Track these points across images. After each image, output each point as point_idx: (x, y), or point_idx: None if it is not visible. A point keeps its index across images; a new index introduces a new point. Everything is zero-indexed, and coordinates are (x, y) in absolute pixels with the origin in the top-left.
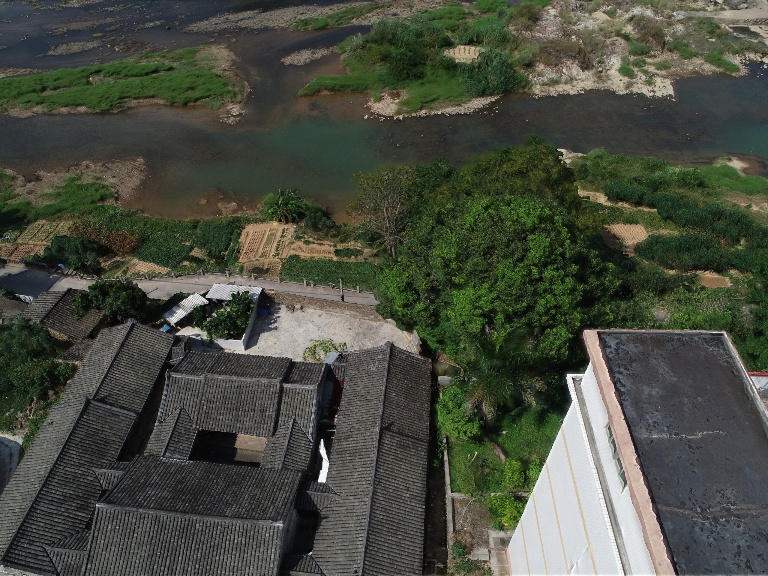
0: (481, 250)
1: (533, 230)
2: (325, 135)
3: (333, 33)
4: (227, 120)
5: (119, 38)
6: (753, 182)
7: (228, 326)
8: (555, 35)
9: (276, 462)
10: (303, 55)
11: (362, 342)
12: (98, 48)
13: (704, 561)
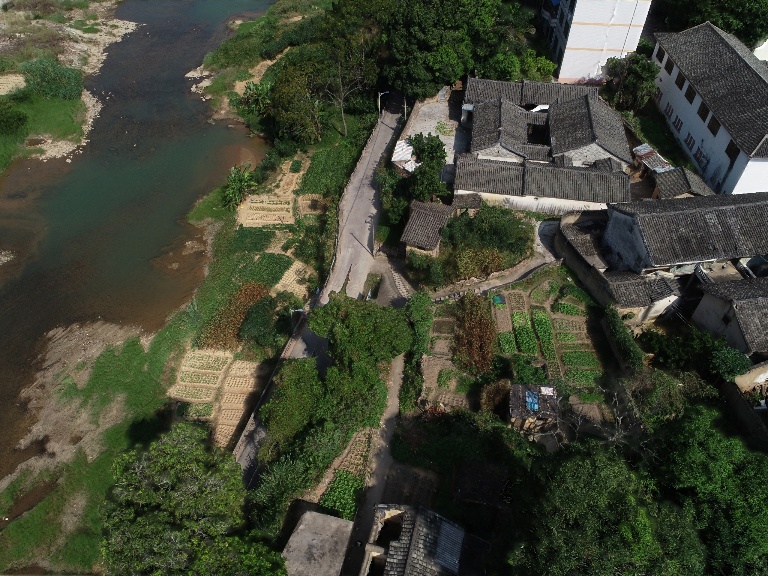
0: None
1: None
2: (82, 191)
3: None
4: (0, 261)
5: None
6: (265, 20)
7: None
8: (5, 41)
9: (543, 117)
10: None
11: (436, 117)
12: None
13: None
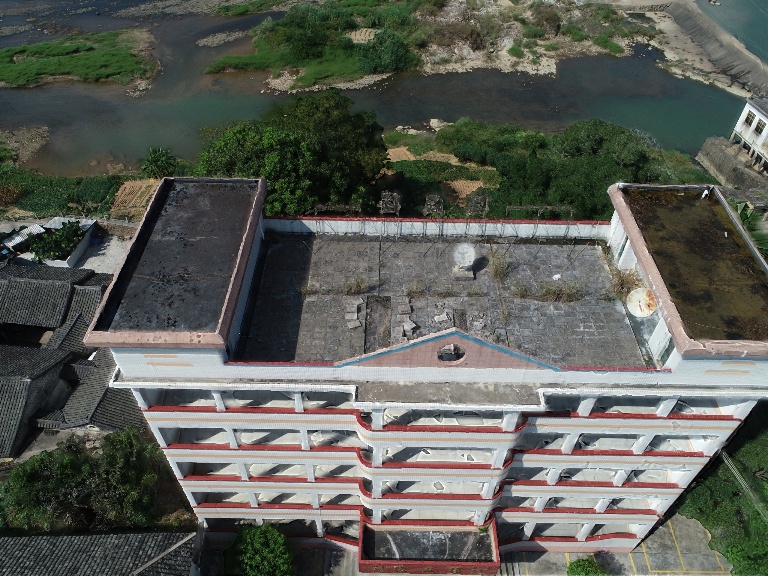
0: (223, 166)
1: (271, 151)
2: (222, 107)
3: (251, 18)
4: (133, 94)
5: (50, 22)
6: None
7: (54, 248)
8: (455, 19)
9: (55, 345)
10: (218, 38)
11: None
12: (28, 31)
13: (141, 302)
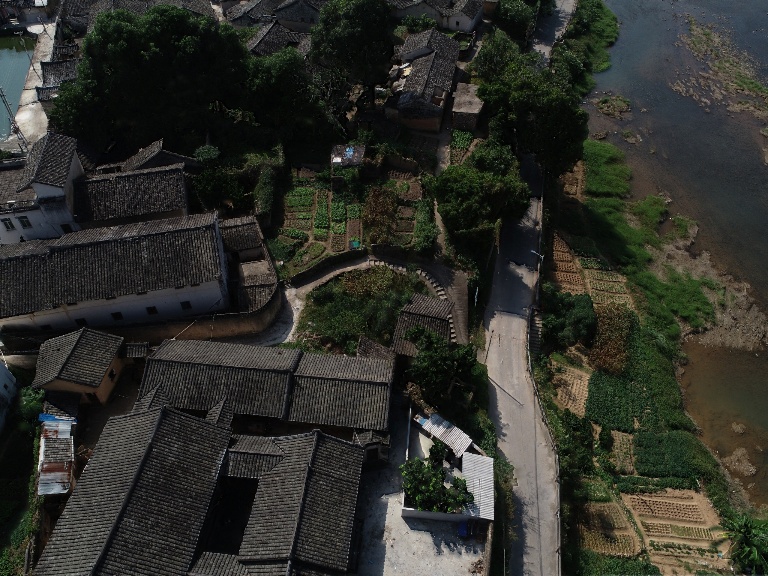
0: None
1: None
2: None
3: None
4: None
5: None
6: None
7: None
8: None
9: (201, 569)
10: None
11: None
12: None
13: None
